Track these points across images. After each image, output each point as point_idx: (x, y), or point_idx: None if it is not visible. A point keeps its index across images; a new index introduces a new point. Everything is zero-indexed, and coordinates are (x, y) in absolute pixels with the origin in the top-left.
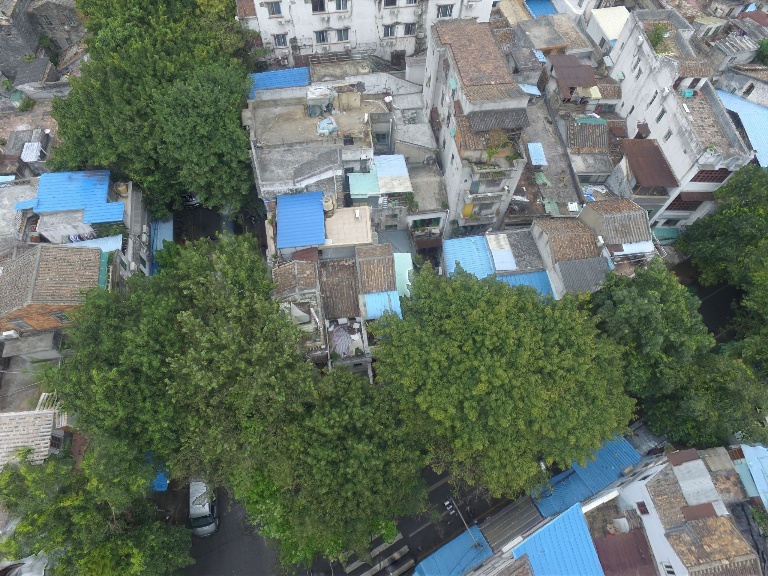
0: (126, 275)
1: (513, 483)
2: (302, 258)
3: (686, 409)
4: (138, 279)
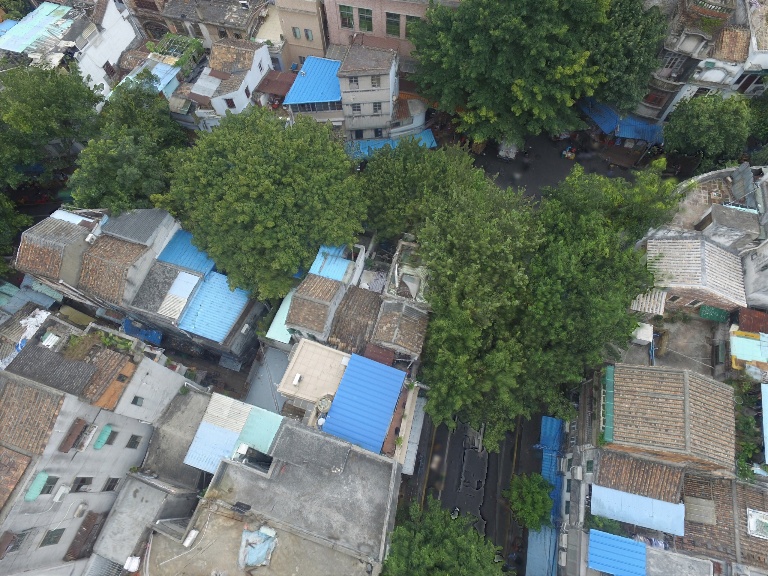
0: (587, 456)
1: (315, 122)
2: (383, 356)
3: (168, 116)
4: (568, 377)
